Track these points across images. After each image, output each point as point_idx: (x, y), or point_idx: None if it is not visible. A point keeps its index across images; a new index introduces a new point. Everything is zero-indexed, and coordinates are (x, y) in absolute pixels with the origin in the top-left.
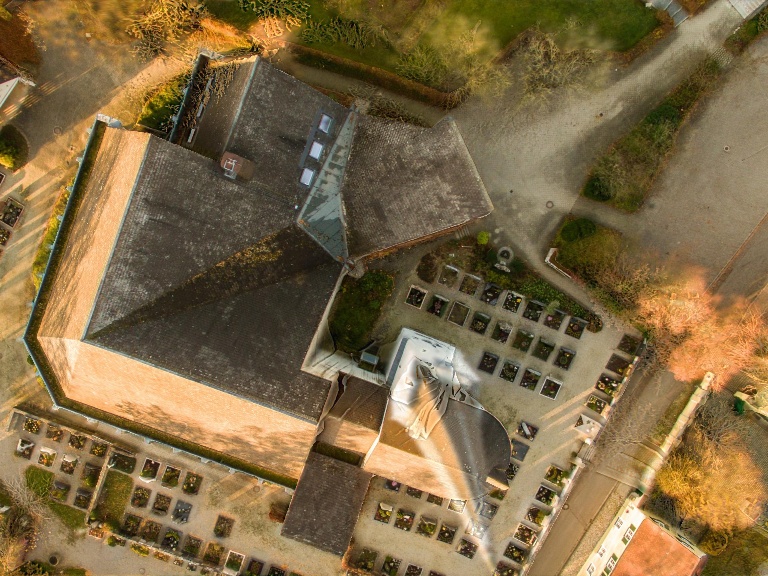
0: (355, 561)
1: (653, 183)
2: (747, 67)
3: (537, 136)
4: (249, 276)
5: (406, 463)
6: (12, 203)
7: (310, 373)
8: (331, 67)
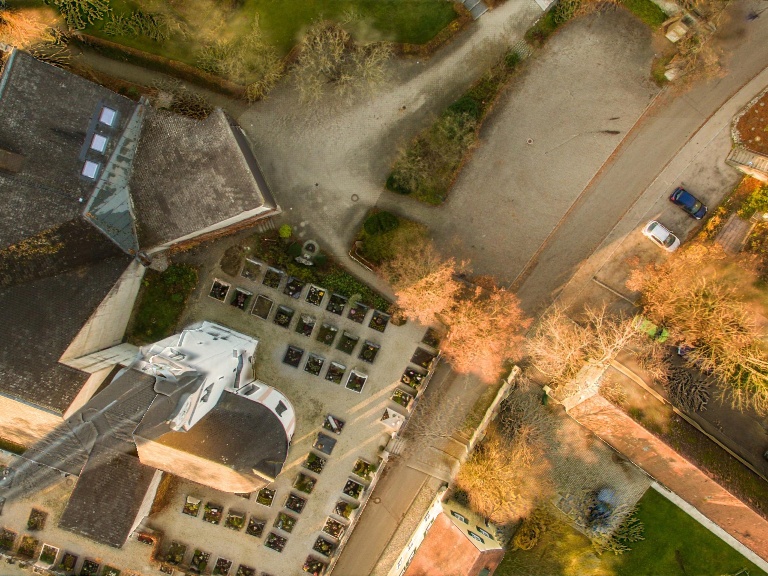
0: (165, 554)
1: (457, 176)
2: (548, 59)
3: (341, 129)
4: (24, 268)
5: (170, 455)
6: None
7: (68, 365)
8: (134, 60)
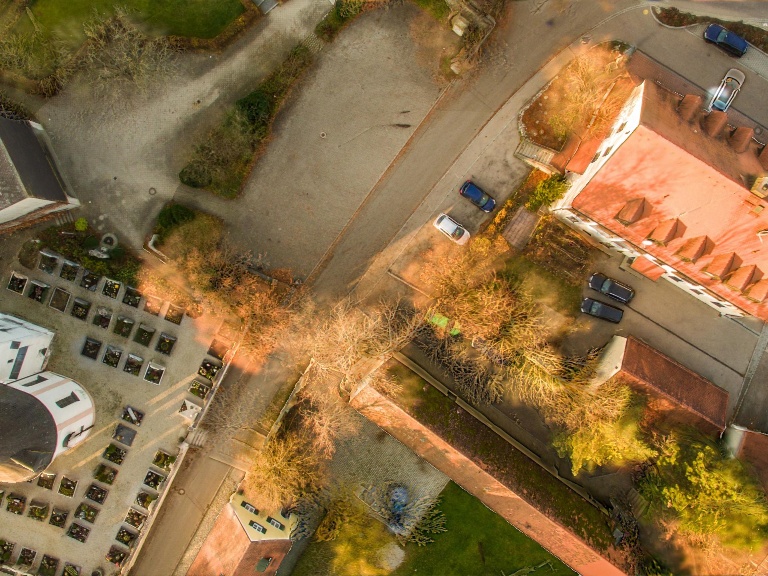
0: None
1: (252, 170)
2: (339, 53)
3: (137, 123)
4: None
5: None
6: None
7: None
8: None
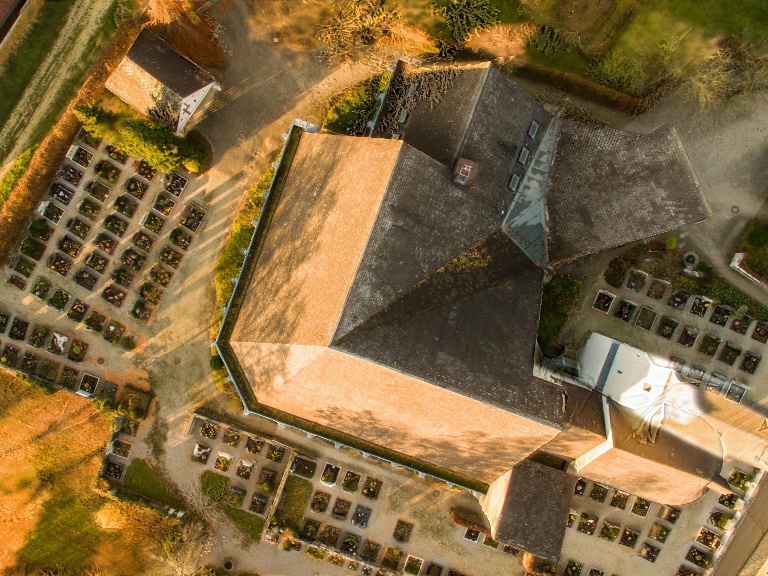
0: (537, 565)
1: None
2: None
3: (724, 141)
4: (465, 281)
5: (632, 468)
6: (194, 208)
7: (542, 379)
8: (519, 72)
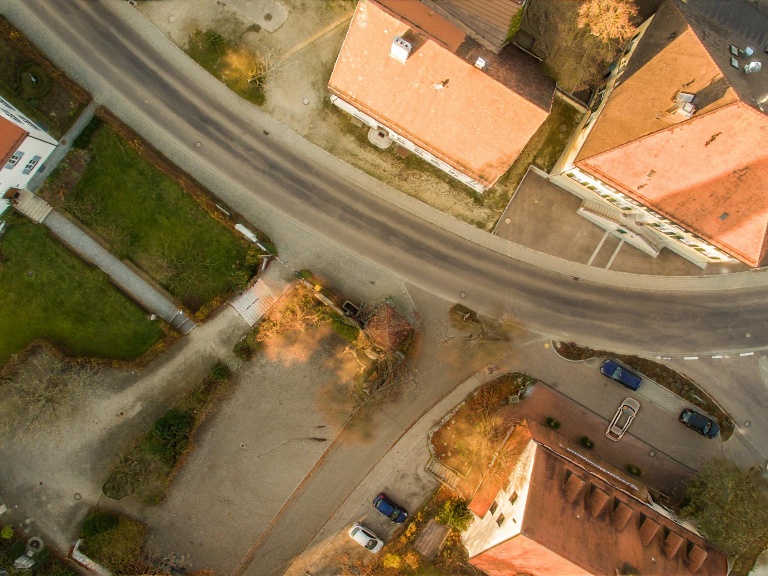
0: None
1: (174, 478)
2: (257, 371)
3: (62, 433)
4: None
5: None
6: None
7: None
8: None
